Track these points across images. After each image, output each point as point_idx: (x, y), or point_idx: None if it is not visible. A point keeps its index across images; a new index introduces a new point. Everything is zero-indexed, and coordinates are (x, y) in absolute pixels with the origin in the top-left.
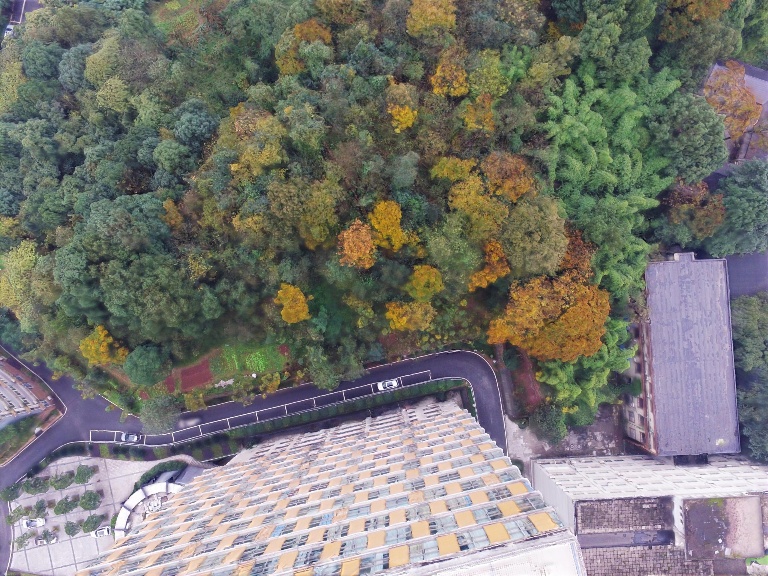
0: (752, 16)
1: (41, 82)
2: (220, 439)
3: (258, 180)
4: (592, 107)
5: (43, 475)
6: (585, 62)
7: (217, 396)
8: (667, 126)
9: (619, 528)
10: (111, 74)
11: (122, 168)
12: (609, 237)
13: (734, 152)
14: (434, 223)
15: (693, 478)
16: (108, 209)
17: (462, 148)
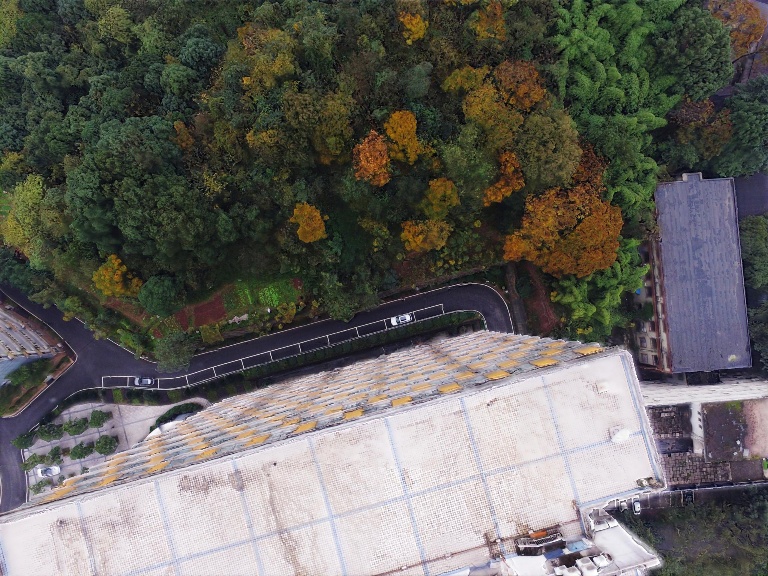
0: None
1: (40, 15)
2: (235, 379)
3: (271, 94)
4: (599, 24)
5: (56, 423)
6: None
7: (231, 335)
8: (674, 41)
9: None
10: (112, 4)
11: (130, 92)
12: (621, 151)
13: (736, 78)
14: (448, 138)
15: (707, 391)
16: (119, 127)
17: (475, 56)
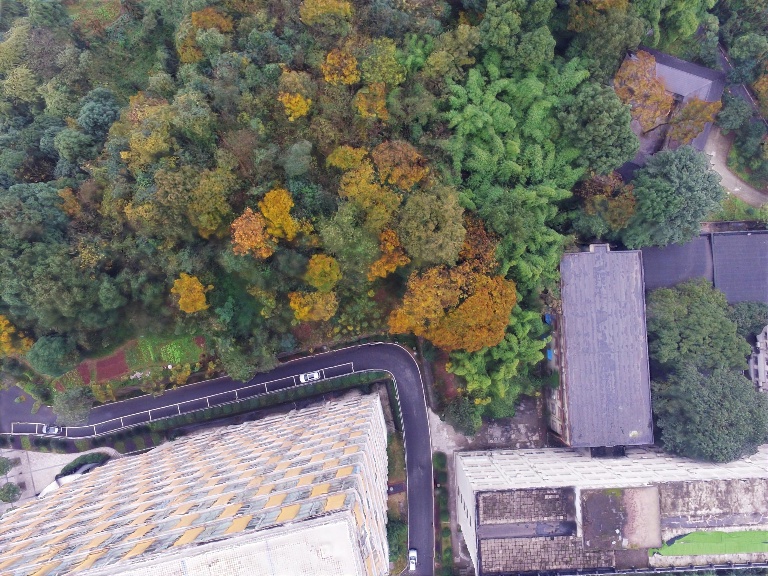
0: (669, 7)
1: None
2: (141, 431)
3: (149, 168)
4: (500, 97)
5: None
6: (490, 51)
7: (136, 388)
8: (574, 116)
9: (521, 519)
10: (19, 63)
11: (22, 157)
12: (513, 227)
13: (658, 144)
14: (333, 212)
15: (603, 469)
16: None
17: (353, 136)
